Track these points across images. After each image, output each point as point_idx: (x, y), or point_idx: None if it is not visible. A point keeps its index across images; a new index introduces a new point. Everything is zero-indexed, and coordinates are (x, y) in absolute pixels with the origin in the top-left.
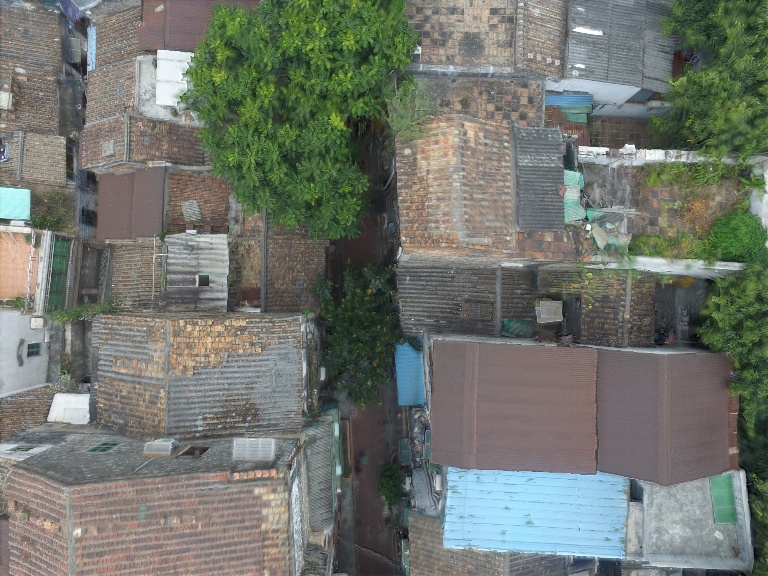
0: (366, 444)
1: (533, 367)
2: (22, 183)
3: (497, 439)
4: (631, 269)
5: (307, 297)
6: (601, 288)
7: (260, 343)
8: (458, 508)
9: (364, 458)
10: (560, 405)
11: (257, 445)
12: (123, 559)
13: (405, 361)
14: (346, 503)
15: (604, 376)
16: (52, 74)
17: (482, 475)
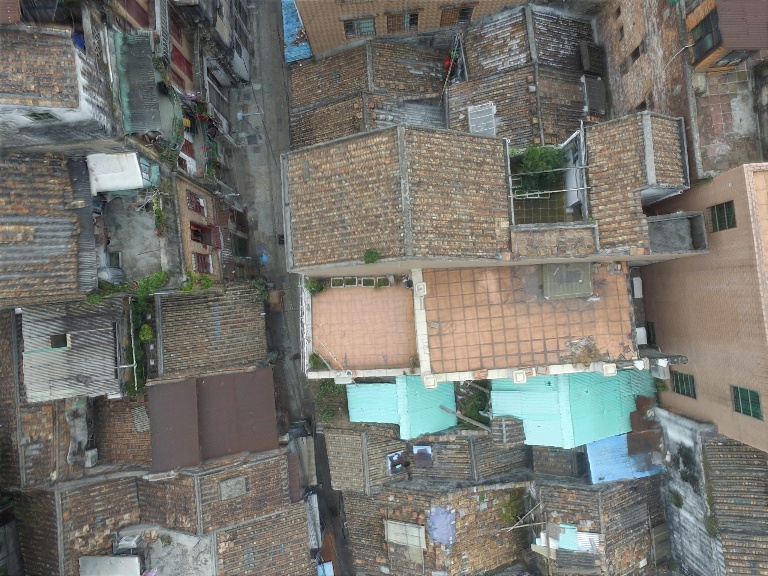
0: None
1: None
2: (361, 429)
3: None
4: None
5: None
6: None
7: None
8: None
9: None
10: None
11: None
12: None
13: None
14: None
15: None
16: (357, 567)
17: None
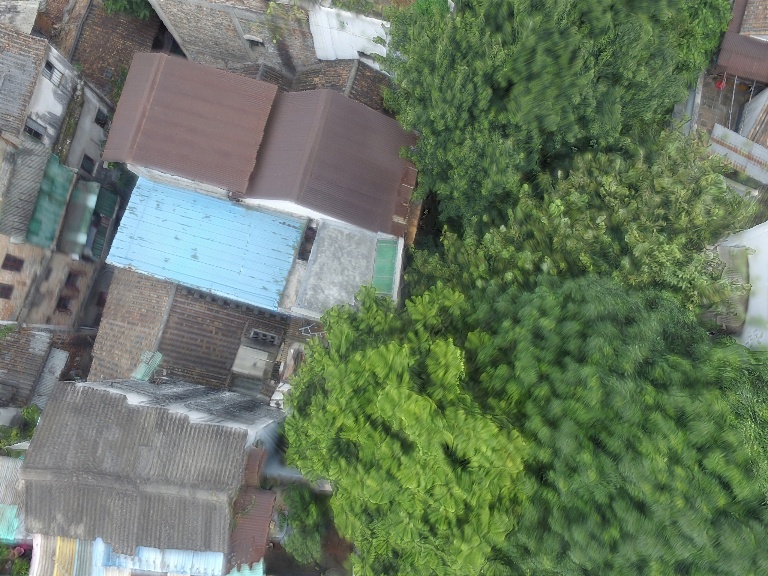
0: None
1: (211, 86)
2: None
3: (160, 141)
4: (357, 59)
5: (111, 90)
6: (332, 78)
7: None
8: (130, 228)
9: None
10: (227, 124)
11: None
12: None
13: None
14: None
15: (282, 116)
16: None
17: (162, 203)
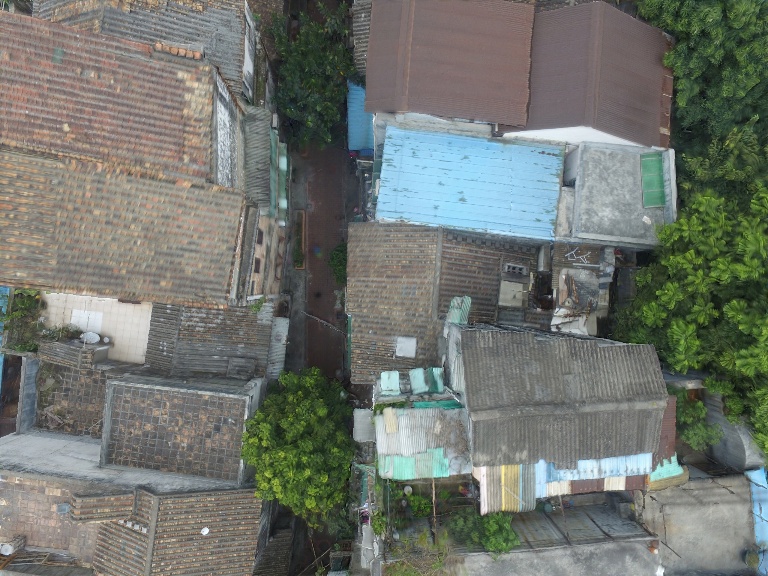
0: (321, 238)
1: (469, 15)
2: None
3: (430, 83)
4: None
5: (263, 40)
6: None
7: (202, 3)
8: (392, 181)
9: (318, 252)
10: (494, 54)
11: (186, 49)
12: (35, 96)
13: (357, 105)
14: (298, 295)
15: (540, 38)
16: None
17: (418, 150)
